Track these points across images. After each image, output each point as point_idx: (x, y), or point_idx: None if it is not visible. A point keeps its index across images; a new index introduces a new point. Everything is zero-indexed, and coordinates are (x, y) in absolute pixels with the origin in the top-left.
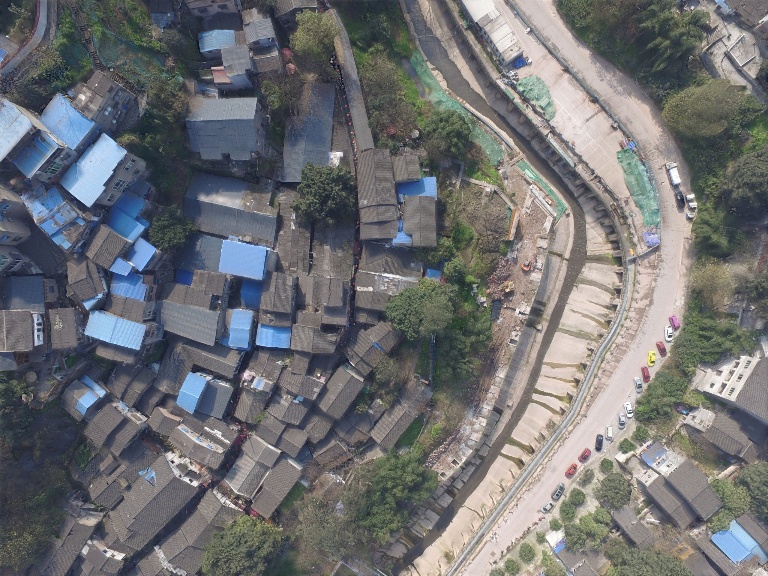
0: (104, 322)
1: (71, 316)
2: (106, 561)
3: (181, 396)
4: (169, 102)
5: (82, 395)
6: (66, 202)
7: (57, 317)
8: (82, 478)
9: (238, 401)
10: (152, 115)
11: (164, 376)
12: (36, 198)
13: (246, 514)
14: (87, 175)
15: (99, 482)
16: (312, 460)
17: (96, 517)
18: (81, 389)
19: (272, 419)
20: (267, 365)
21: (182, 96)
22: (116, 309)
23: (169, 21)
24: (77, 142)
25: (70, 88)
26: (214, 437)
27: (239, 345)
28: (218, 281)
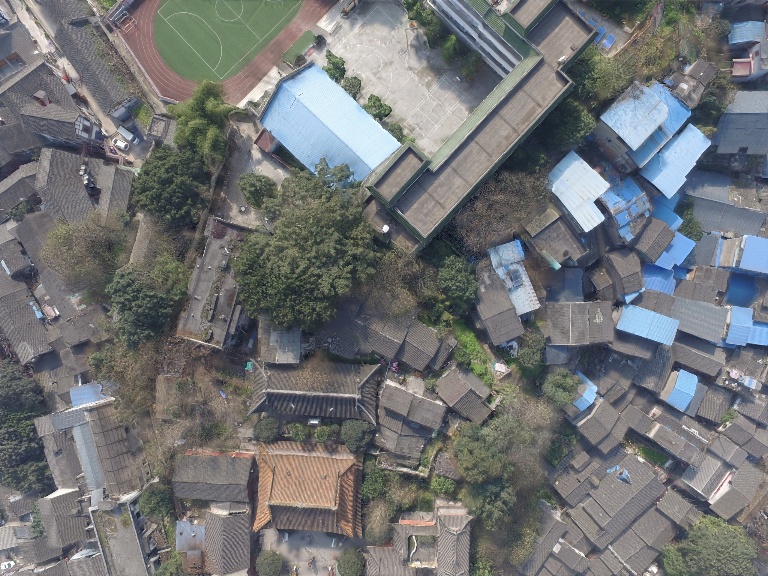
0: (639, 317)
1: (610, 310)
2: (580, 560)
3: (674, 393)
4: (727, 93)
5: (584, 390)
6: (645, 193)
7: (599, 310)
8: (551, 475)
9: (702, 400)
10: (708, 106)
11: (648, 373)
12: (609, 188)
13: (708, 515)
14: (671, 166)
15: (567, 479)
16: (763, 461)
17: (556, 515)
18: (582, 384)
19: (742, 419)
20: (750, 364)
21: (735, 88)
22: (647, 304)
23: (719, 11)
24: (673, 132)
25: (651, 77)
26: (690, 436)
27: (737, 343)
28: (723, 277)
